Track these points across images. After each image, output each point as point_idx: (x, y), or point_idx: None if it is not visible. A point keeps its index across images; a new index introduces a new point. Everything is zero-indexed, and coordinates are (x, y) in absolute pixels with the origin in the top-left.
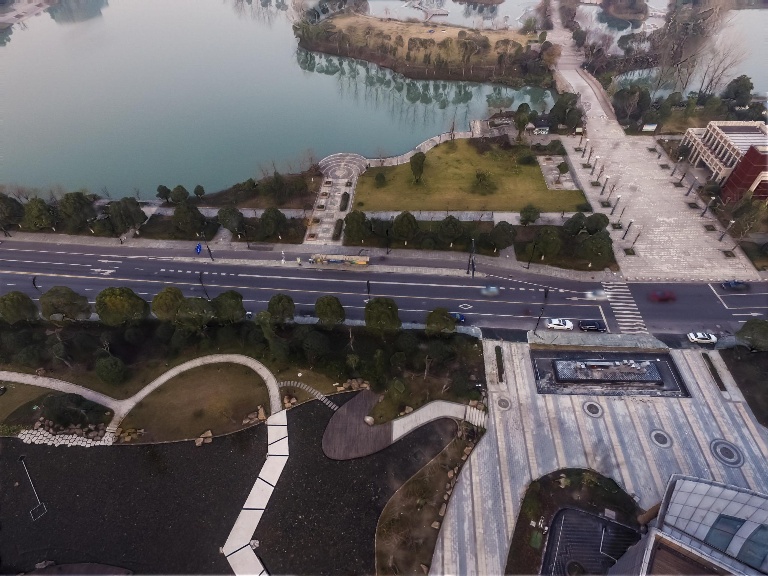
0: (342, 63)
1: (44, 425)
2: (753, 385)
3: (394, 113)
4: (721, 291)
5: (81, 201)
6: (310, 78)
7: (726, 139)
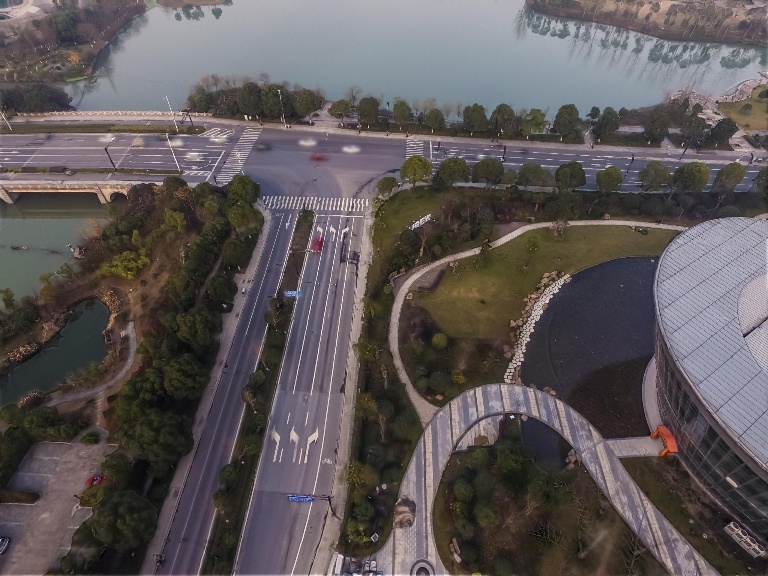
0: (580, 27)
1: None
2: None
3: (631, 72)
4: None
5: None
6: (522, 43)
7: None
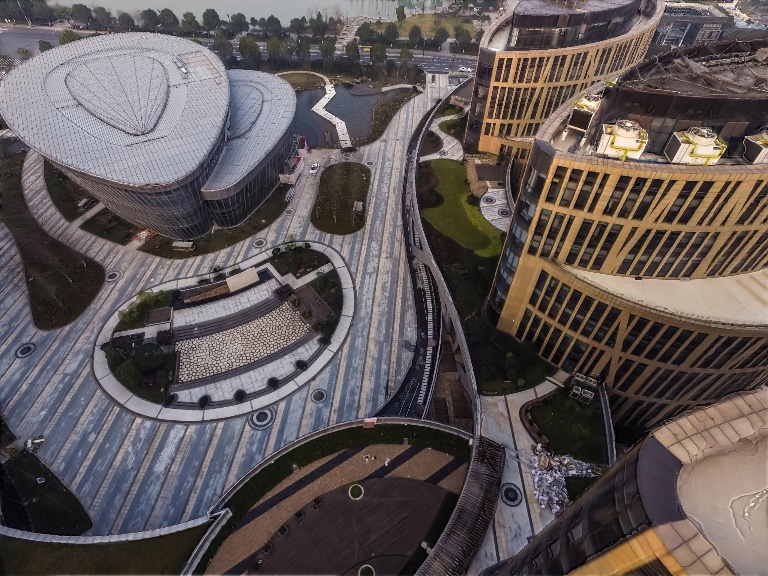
0: None
1: None
2: None
3: None
4: None
5: (215, 13)
6: None
7: None
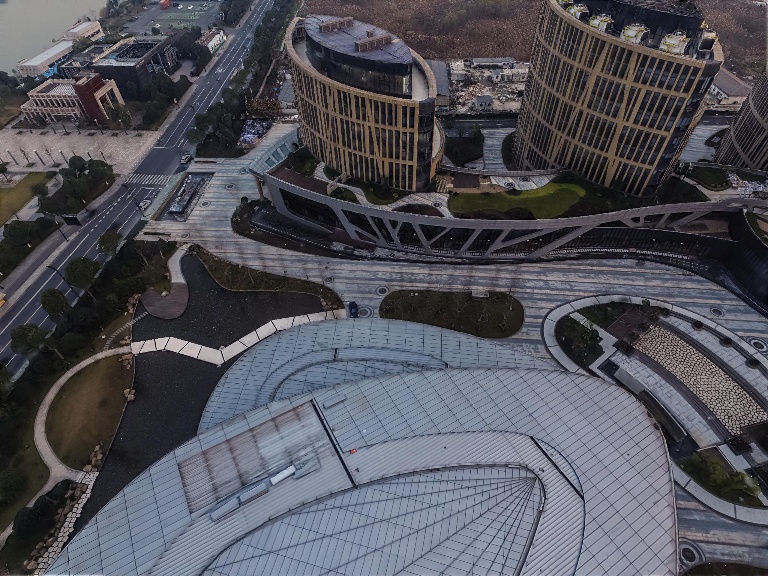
0: None
1: (36, 558)
2: (218, 153)
3: None
4: (161, 145)
5: None
6: None
7: (52, 95)
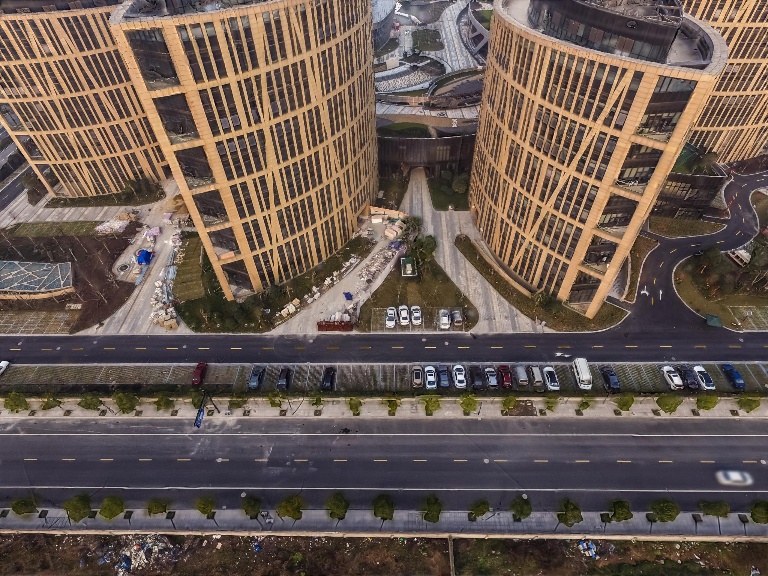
0: None
1: None
2: None
3: None
4: None
5: None
6: None
7: None
